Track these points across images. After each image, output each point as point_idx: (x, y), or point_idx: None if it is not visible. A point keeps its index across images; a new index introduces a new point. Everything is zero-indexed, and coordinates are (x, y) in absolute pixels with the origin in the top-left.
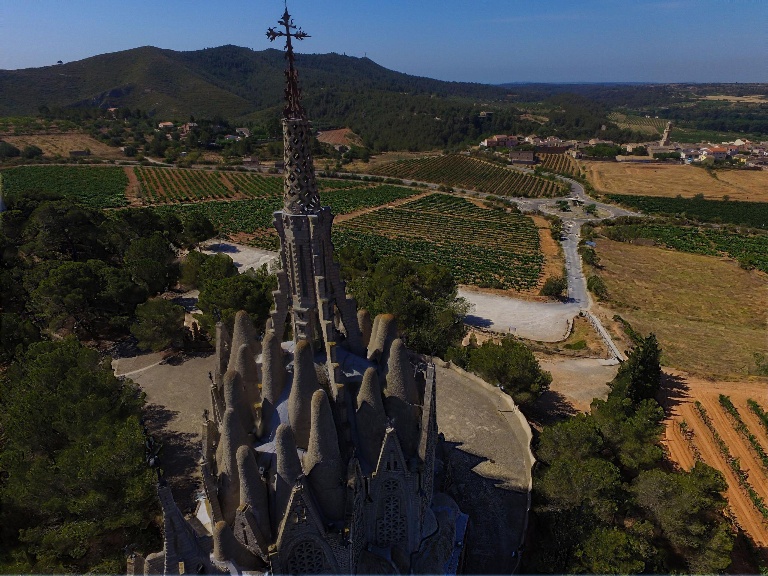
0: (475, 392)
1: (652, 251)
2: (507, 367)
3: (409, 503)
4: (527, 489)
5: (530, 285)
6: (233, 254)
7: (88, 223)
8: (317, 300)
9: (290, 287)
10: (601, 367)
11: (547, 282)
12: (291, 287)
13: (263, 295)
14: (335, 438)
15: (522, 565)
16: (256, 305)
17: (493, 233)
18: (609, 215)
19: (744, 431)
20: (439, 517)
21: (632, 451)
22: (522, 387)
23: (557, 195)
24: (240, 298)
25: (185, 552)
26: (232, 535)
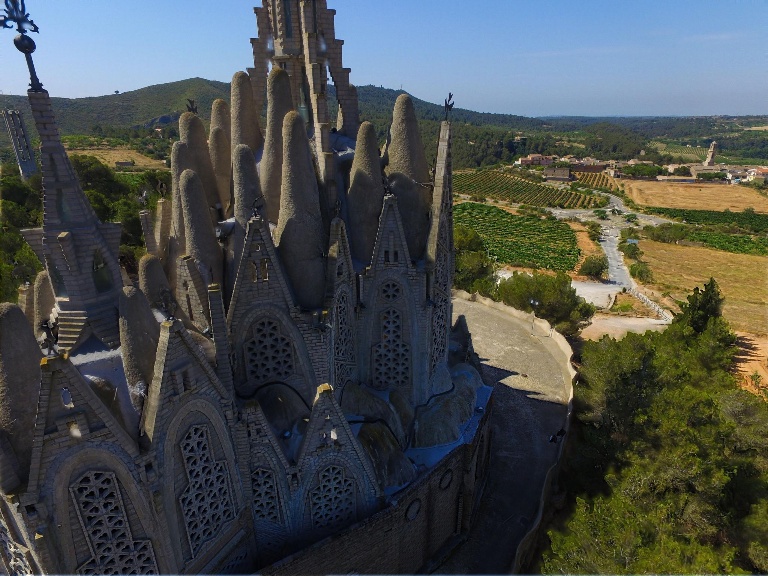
0: (504, 320)
1: (701, 251)
2: (542, 292)
3: (414, 323)
4: (567, 401)
5: (567, 269)
6: None
7: (112, 181)
8: (303, 40)
9: (271, 29)
10: (651, 325)
11: (586, 262)
12: (272, 28)
13: None
14: (314, 188)
15: (561, 470)
16: None
17: (527, 233)
18: (651, 224)
19: None
20: (455, 380)
21: (697, 380)
22: (560, 316)
23: (594, 206)
24: None
25: (74, 222)
26: (165, 279)
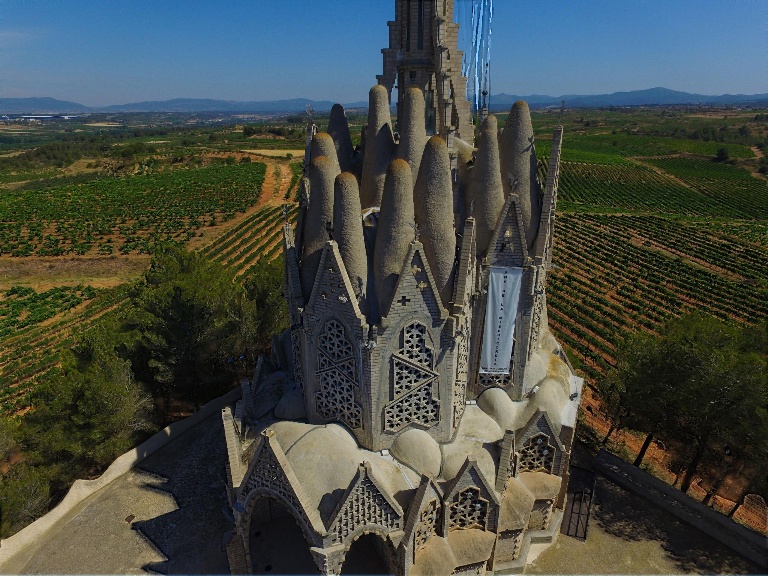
0: None
1: None
2: None
3: None
4: (128, 471)
5: None
6: None
7: None
8: None
9: None
10: None
11: None
12: None
13: None
14: None
15: None
16: None
17: None
18: None
19: None
20: None
21: None
22: None
23: None
24: None
25: None
26: None
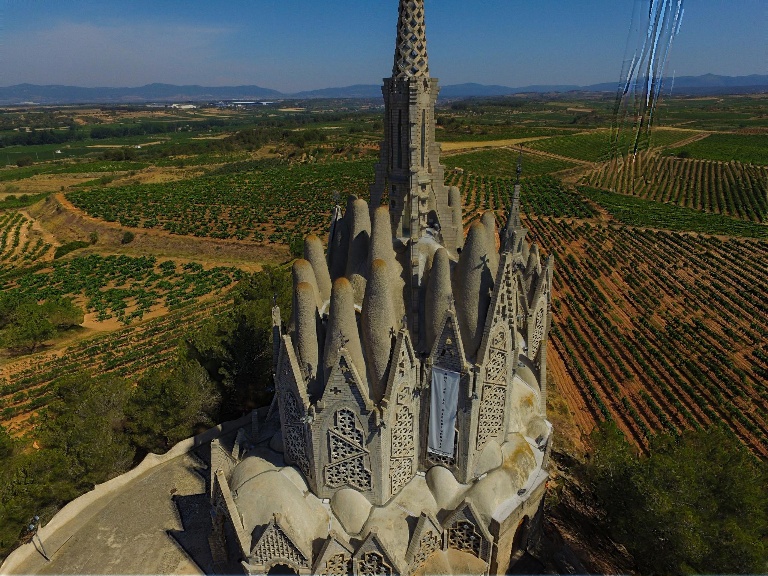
0: None
1: None
2: None
3: None
4: (186, 453)
5: None
6: None
7: None
8: None
9: None
10: None
11: None
12: None
13: None
14: None
15: None
16: None
17: None
18: None
19: None
20: None
21: None
22: None
23: None
24: None
25: None
26: None
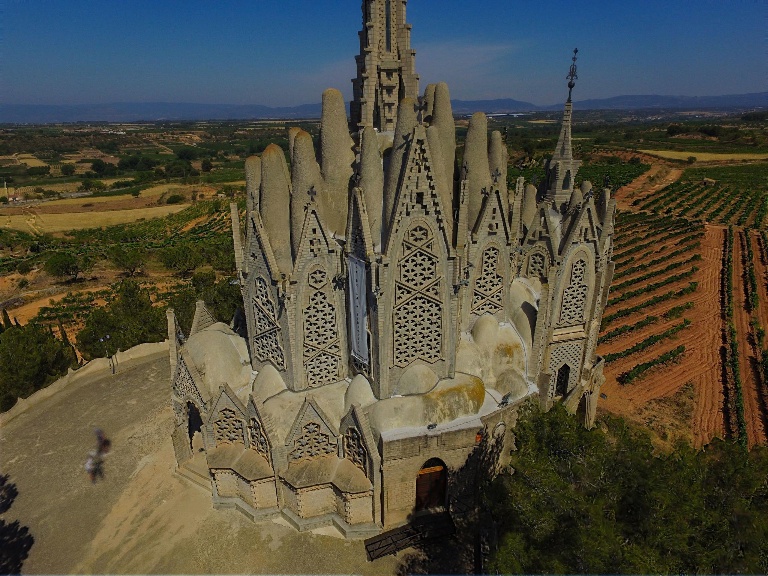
0: (65, 399)
1: None
2: None
3: None
4: None
5: None
6: None
7: None
8: None
9: None
10: None
11: None
12: None
13: None
14: None
15: None
16: None
17: None
18: None
19: (73, 327)
20: None
21: None
22: (62, 363)
23: None
24: None
25: None
26: None
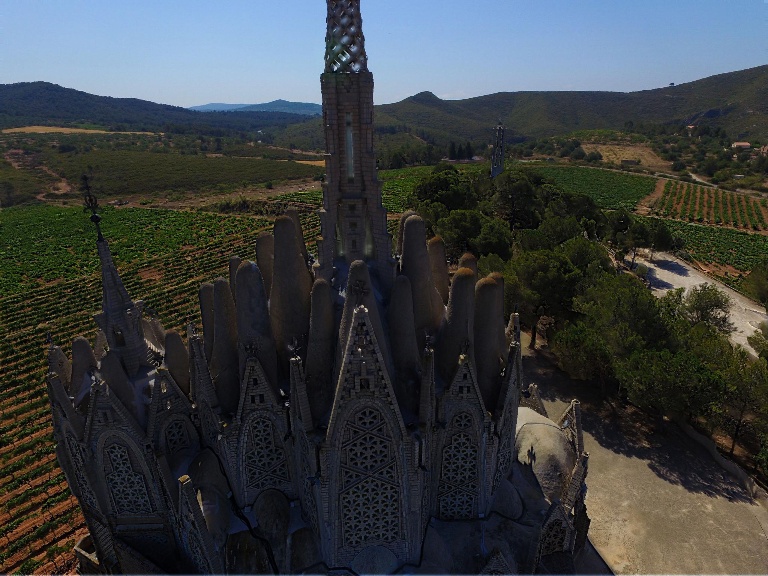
0: None
1: None
2: None
3: (316, 485)
4: None
5: None
6: (676, 275)
7: None
8: None
9: None
10: None
11: None
12: None
13: (567, 282)
14: (253, 325)
15: None
16: (546, 286)
17: None
18: None
19: None
20: None
21: None
22: None
23: None
24: (534, 272)
25: None
26: (175, 347)
